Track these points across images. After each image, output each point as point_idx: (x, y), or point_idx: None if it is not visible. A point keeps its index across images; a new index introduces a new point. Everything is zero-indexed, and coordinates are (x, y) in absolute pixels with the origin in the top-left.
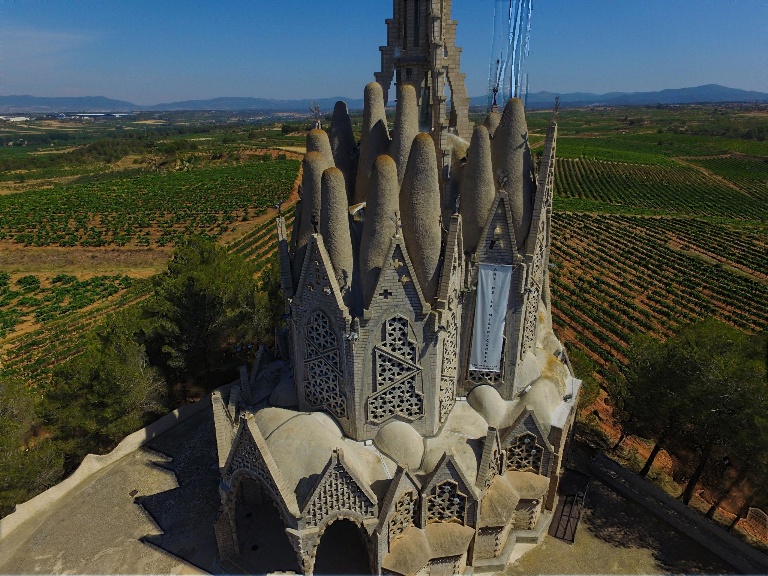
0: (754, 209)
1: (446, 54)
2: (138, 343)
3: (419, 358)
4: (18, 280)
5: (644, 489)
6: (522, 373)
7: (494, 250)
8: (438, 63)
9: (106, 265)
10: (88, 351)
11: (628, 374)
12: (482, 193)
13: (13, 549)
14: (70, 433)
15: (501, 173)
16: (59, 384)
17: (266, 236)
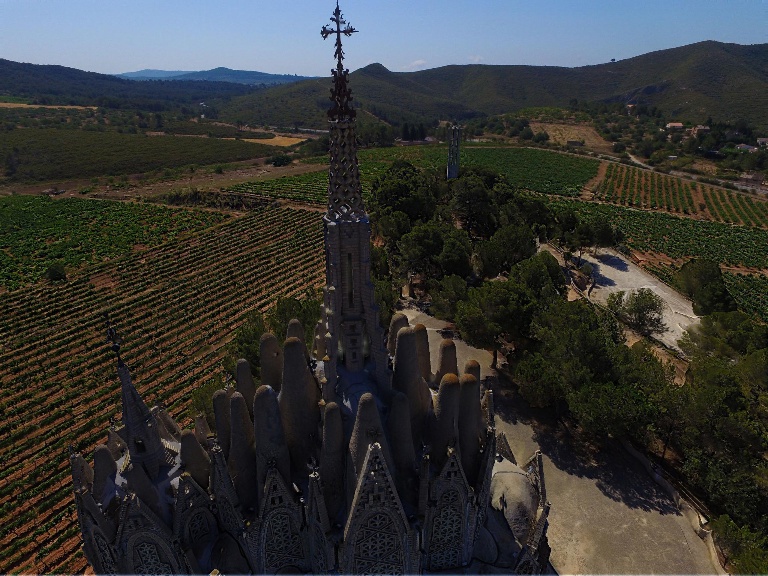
0: None
1: None
2: None
3: None
4: None
5: None
6: None
7: None
8: None
9: None
10: None
11: None
12: None
13: None
14: None
15: None
16: None
17: None
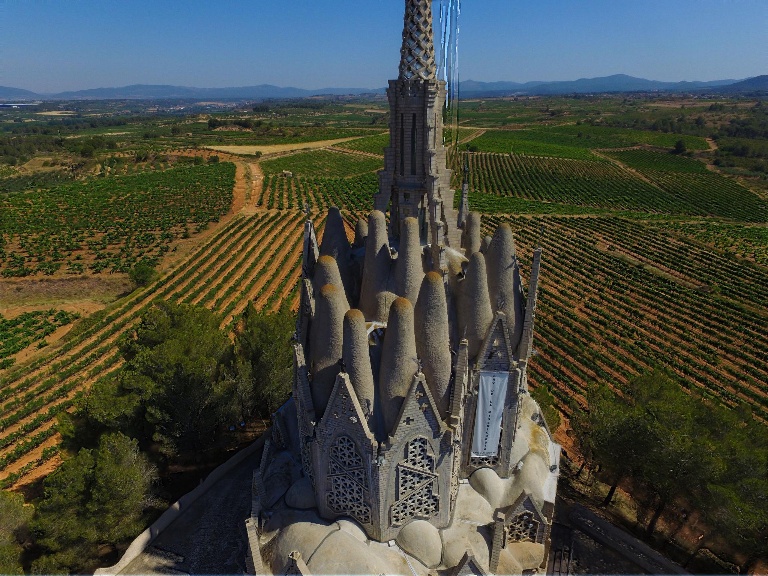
0: (664, 202)
1: None
2: (122, 428)
3: (436, 467)
4: None
5: (617, 535)
6: (514, 451)
7: (493, 359)
8: (435, 192)
9: (35, 297)
10: (42, 414)
11: (579, 393)
12: (481, 310)
13: None
14: (68, 543)
15: (494, 288)
16: (54, 497)
17: (212, 257)
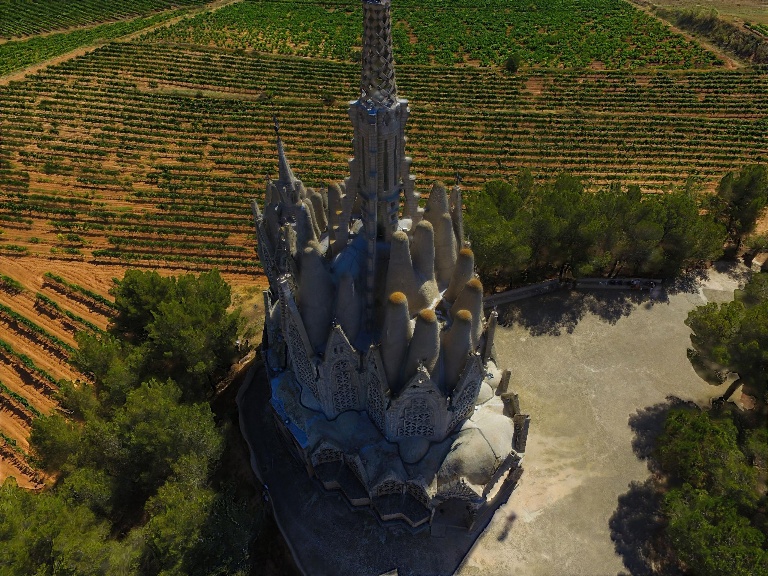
0: (120, 0)
1: None
2: None
3: None
4: None
5: None
6: None
7: None
8: None
9: None
10: None
11: None
12: None
13: None
14: None
15: None
16: None
17: None
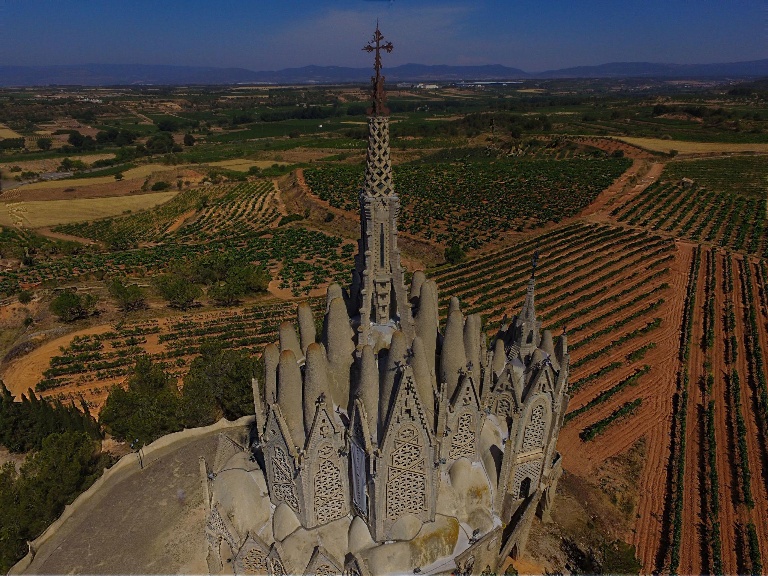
0: None
1: (392, 271)
2: None
3: (294, 478)
4: (343, 246)
5: None
6: (392, 528)
7: None
8: (366, 285)
9: None
10: None
11: None
12: (360, 391)
13: (174, 449)
14: None
15: None
16: (231, 371)
17: (521, 255)
